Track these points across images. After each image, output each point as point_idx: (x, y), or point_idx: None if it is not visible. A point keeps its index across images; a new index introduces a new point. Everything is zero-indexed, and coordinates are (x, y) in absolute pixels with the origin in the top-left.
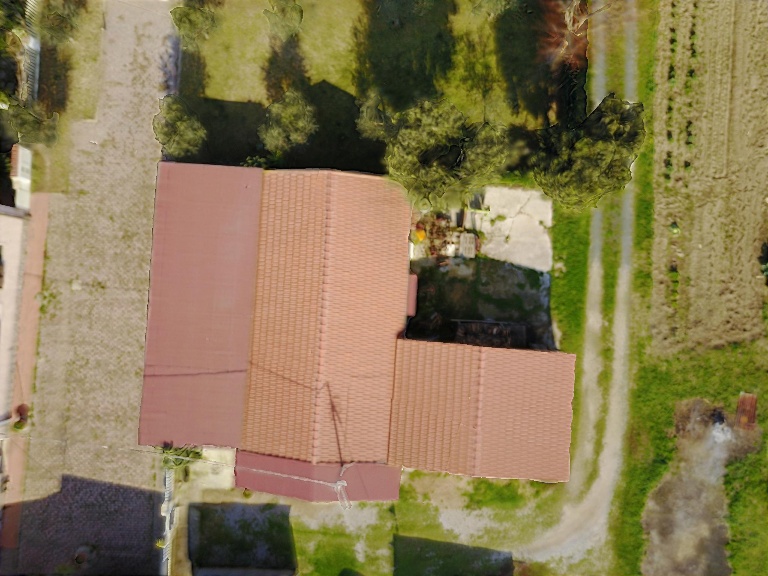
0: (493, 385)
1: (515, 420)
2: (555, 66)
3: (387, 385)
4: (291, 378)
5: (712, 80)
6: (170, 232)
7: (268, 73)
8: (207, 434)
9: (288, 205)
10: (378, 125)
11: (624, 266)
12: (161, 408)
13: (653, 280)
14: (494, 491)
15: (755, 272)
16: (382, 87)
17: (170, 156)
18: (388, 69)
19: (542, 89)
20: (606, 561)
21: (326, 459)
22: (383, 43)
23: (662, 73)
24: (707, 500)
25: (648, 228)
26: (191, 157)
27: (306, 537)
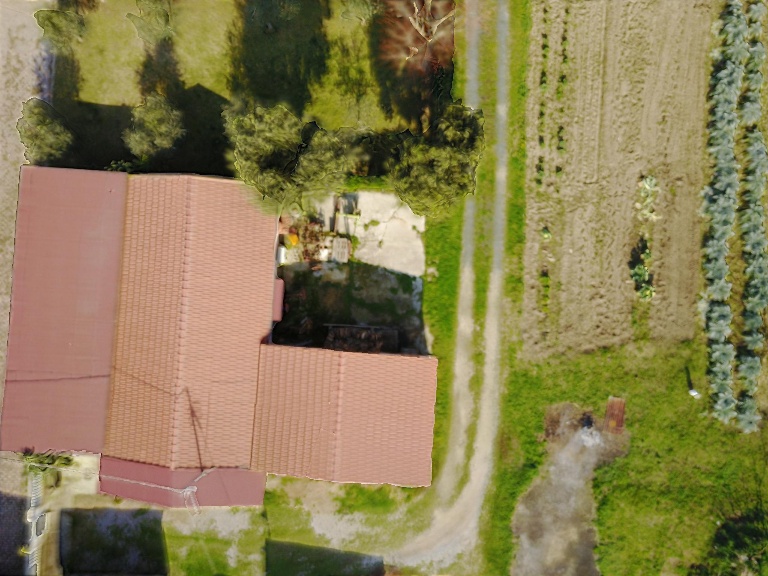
0: (353, 390)
1: (376, 425)
2: (427, 71)
3: (251, 390)
4: (152, 383)
5: (583, 86)
6: (33, 236)
7: (142, 76)
8: (69, 439)
9: (151, 210)
10: None
11: (496, 271)
12: (23, 413)
13: (524, 285)
14: (366, 495)
15: (625, 277)
16: (257, 91)
17: (33, 160)
18: (262, 73)
19: (415, 94)
20: (476, 565)
21: (185, 464)
22: (257, 47)
23: (534, 78)
24: (576, 504)
25: (519, 233)
26: (54, 161)
27: (178, 542)
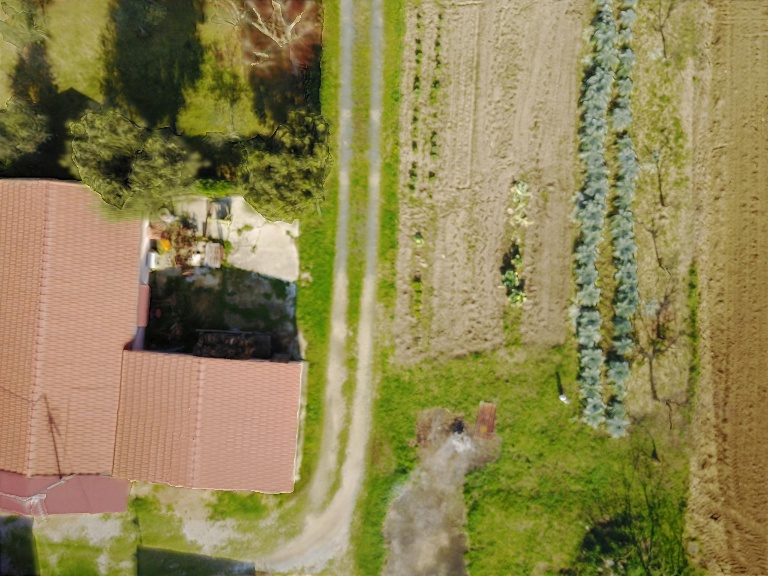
0: (213, 396)
1: (236, 431)
2: (299, 76)
3: (113, 396)
4: (11, 390)
5: (456, 91)
6: None
7: (15, 80)
8: None
9: (12, 215)
10: None
11: (368, 276)
12: None
13: (397, 290)
14: (237, 501)
15: (497, 282)
16: (130, 95)
17: None
18: (136, 77)
19: (288, 99)
20: (347, 571)
21: (43, 472)
22: (131, 51)
23: (408, 84)
24: (447, 509)
25: (392, 238)
26: None
27: (49, 549)
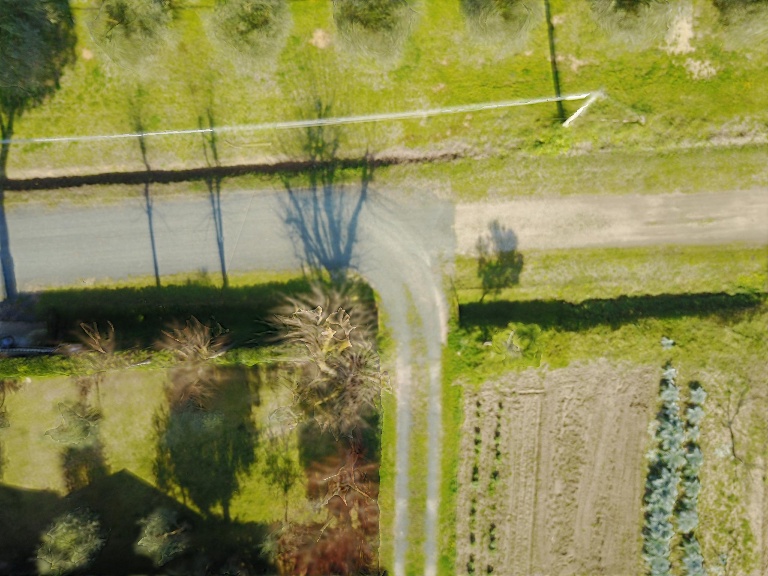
0: None
1: None
2: None
3: None
4: None
5: (516, 482)
6: None
7: (68, 459)
8: None
9: None
10: (168, 536)
11: None
12: None
13: None
14: None
15: None
16: (184, 477)
17: None
18: (190, 459)
19: None
20: None
21: None
22: (185, 432)
23: (466, 473)
24: None
25: None
26: None
27: None
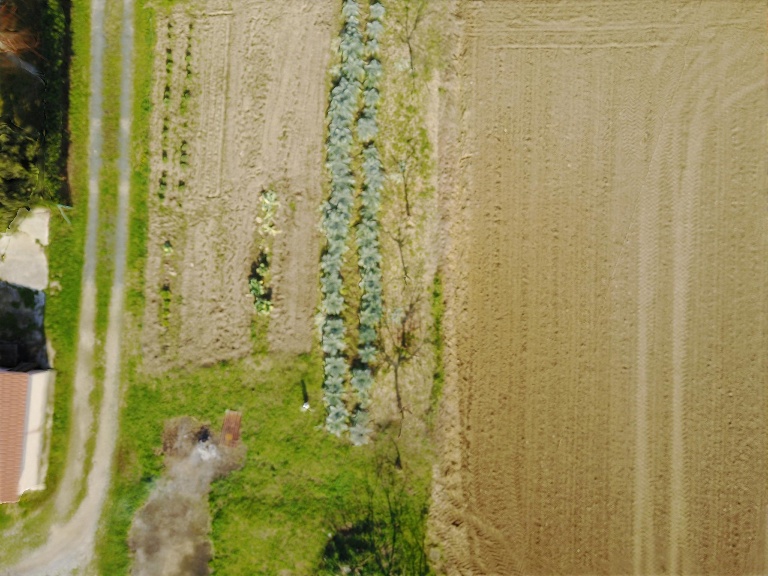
0: None
1: None
2: None
3: None
4: None
5: (207, 101)
6: None
7: None
8: None
9: None
10: None
11: (117, 284)
12: None
13: (146, 298)
14: None
15: (245, 290)
16: None
17: None
18: None
19: (38, 107)
20: None
21: None
22: None
23: (158, 93)
24: (192, 517)
25: (141, 247)
26: None
27: None
